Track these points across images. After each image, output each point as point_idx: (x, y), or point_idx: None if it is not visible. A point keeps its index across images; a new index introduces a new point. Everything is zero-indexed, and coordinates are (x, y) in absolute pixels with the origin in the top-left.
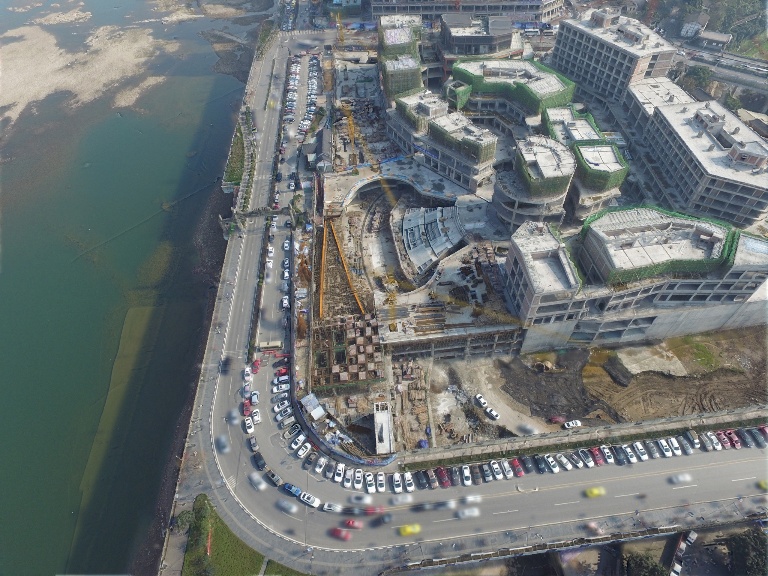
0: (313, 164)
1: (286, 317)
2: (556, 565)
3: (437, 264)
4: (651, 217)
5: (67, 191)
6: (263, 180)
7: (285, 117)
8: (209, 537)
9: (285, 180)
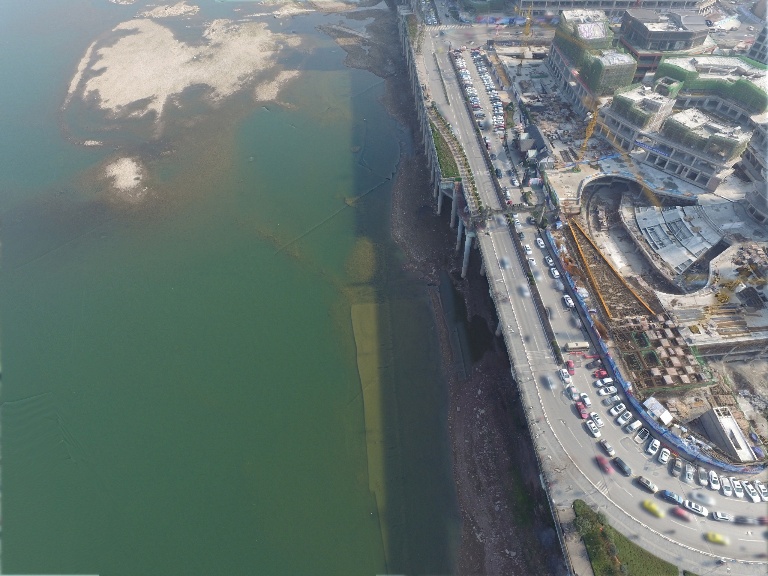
0: (532, 160)
1: (578, 317)
2: None
3: (694, 265)
4: None
5: (241, 185)
6: (482, 176)
7: (475, 112)
8: None
9: (505, 176)
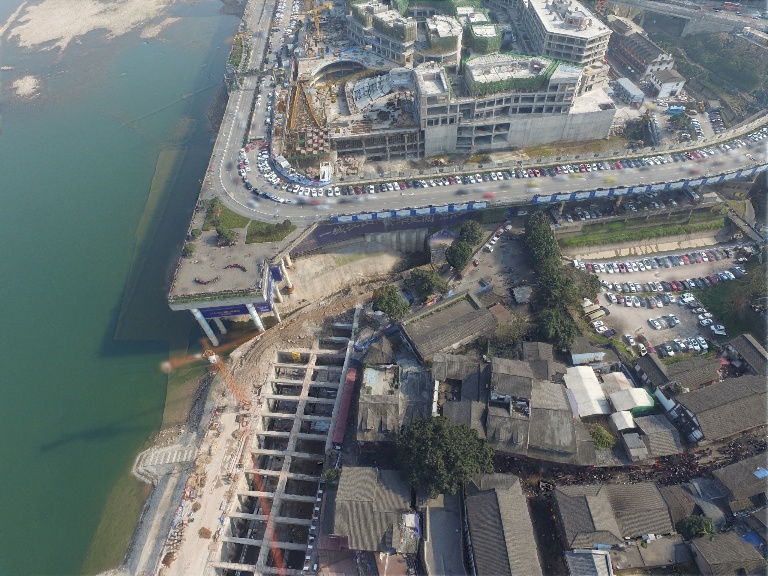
0: (291, 52)
1: (268, 127)
2: (428, 249)
3: None
4: (507, 58)
5: (110, 90)
6: (256, 63)
7: (273, 28)
8: (219, 212)
9: (271, 63)
